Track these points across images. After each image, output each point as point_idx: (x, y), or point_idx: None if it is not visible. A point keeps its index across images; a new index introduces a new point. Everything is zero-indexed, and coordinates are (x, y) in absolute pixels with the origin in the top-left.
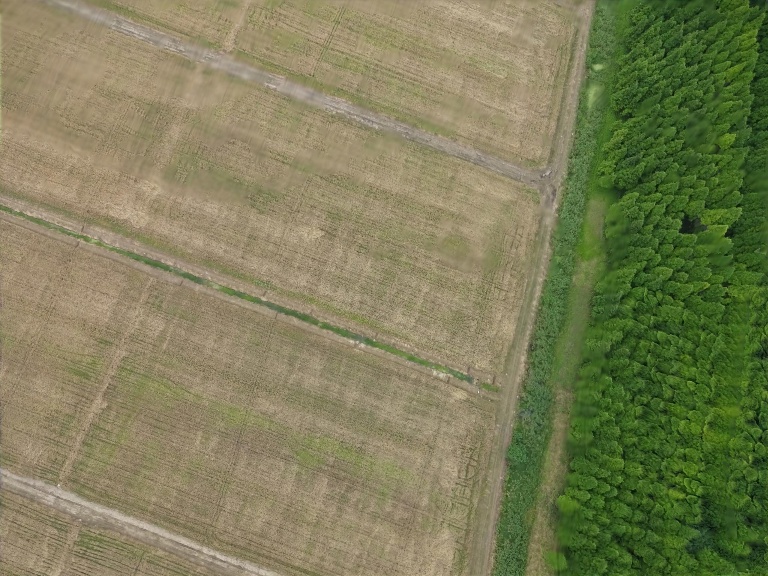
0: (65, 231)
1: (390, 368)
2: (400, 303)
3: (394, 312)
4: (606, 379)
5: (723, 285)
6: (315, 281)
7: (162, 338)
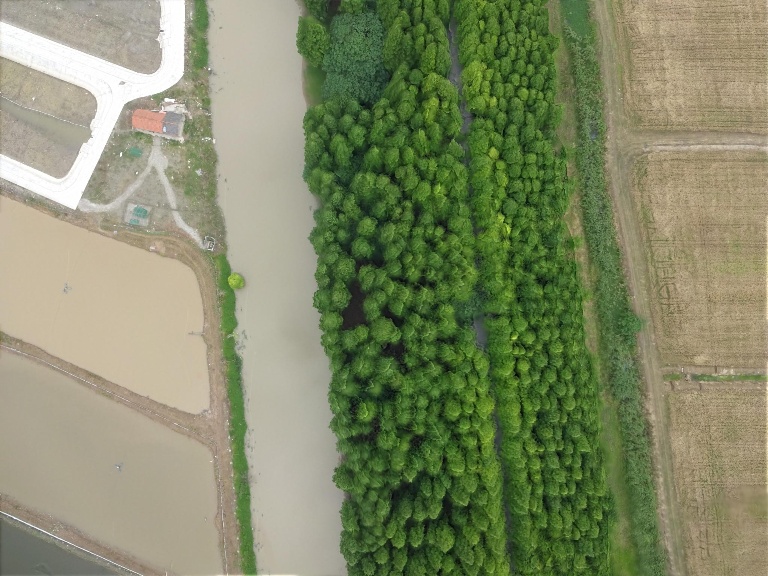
0: None
1: None
2: None
3: None
4: None
5: (537, 570)
6: None
7: None
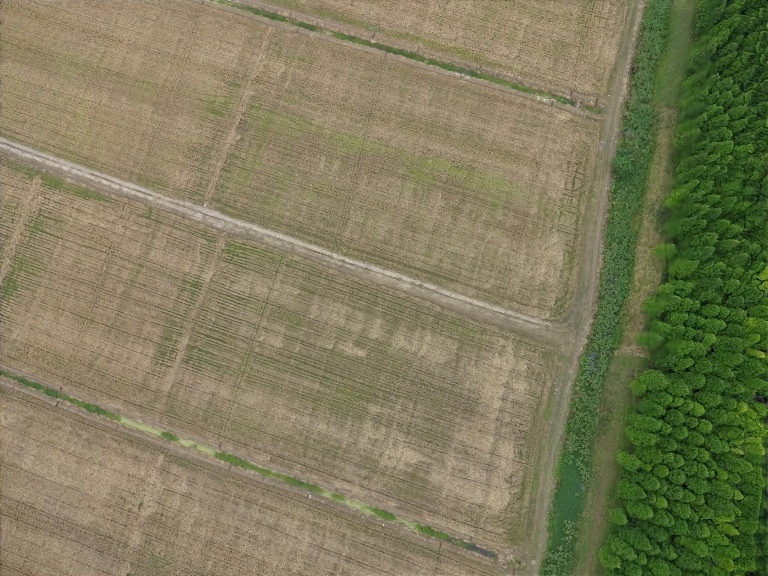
0: None
1: (495, 95)
2: (502, 36)
3: (497, 45)
4: (713, 77)
5: None
6: (420, 21)
7: (284, 79)
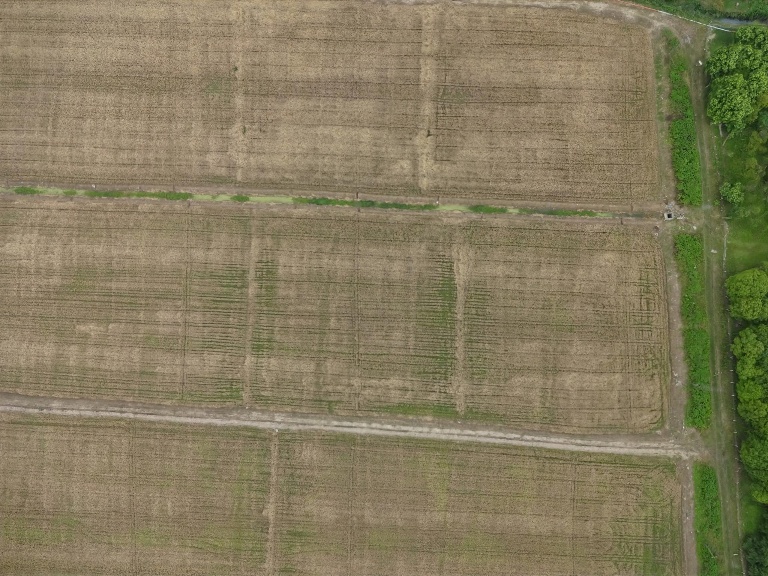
0: None
1: None
2: None
3: None
4: None
5: None
6: None
7: None
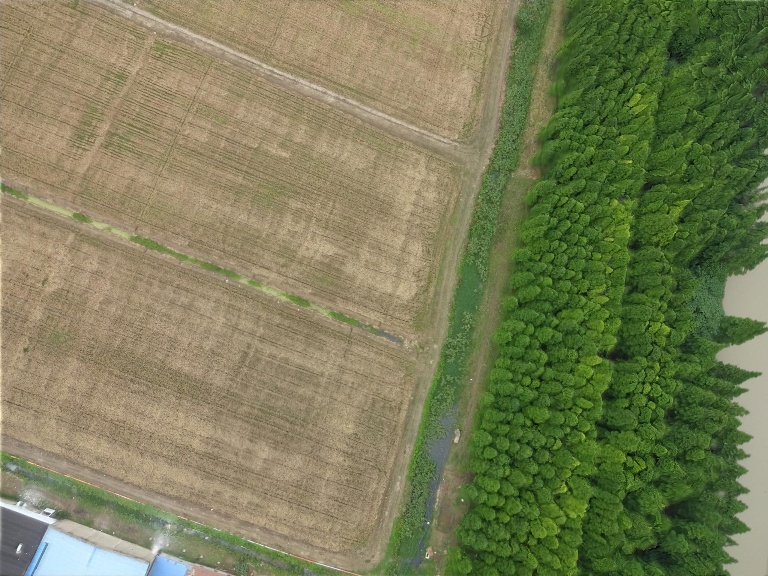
0: None
1: None
2: None
3: None
4: None
5: None
6: None
7: None
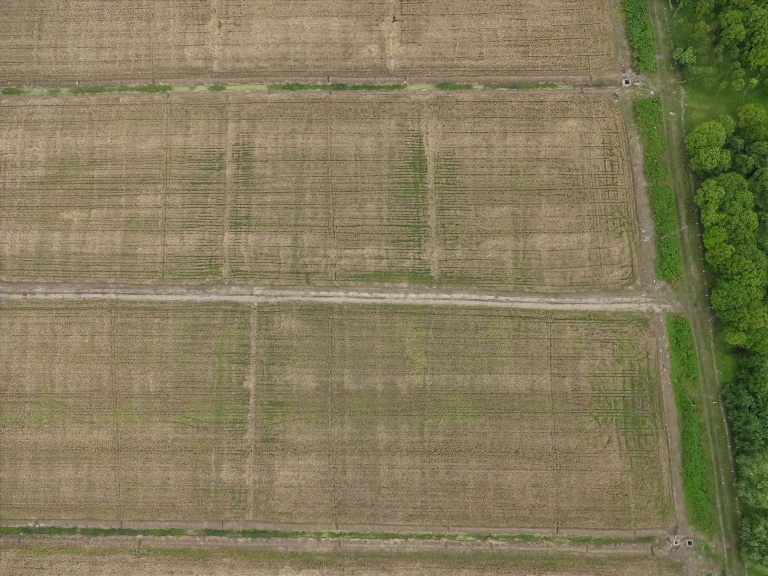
0: (356, 535)
1: None
2: None
3: (7, 571)
4: None
5: None
6: (94, 575)
7: (219, 463)
